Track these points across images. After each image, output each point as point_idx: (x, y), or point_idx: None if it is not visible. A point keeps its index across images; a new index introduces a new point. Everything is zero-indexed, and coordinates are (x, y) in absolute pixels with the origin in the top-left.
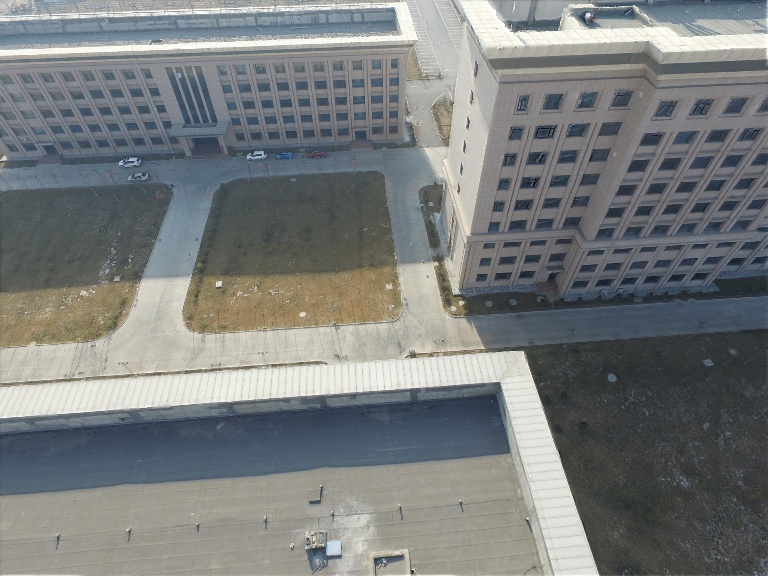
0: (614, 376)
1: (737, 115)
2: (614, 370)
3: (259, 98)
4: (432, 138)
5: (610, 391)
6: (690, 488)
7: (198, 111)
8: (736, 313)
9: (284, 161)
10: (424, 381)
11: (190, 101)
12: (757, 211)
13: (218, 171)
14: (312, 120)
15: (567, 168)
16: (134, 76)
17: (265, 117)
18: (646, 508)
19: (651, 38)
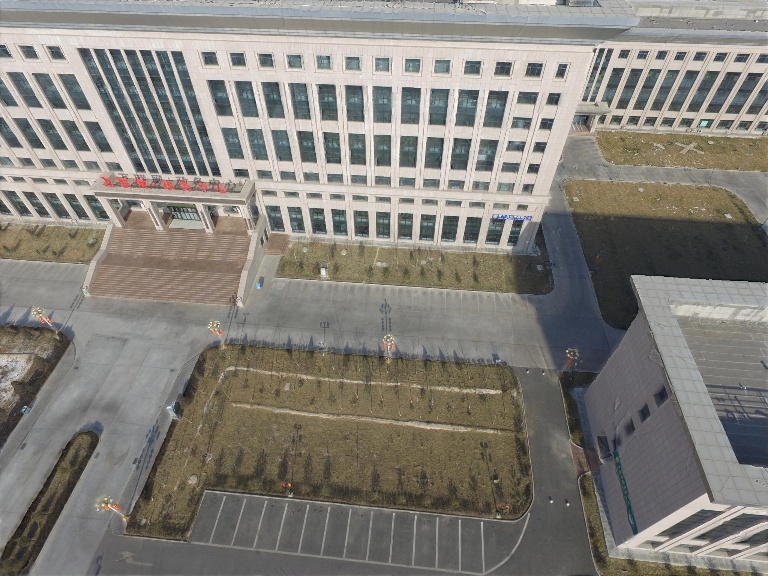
0: None
1: None
2: None
3: None
4: (534, 393)
5: None
6: None
7: None
8: None
9: None
10: None
11: None
12: None
13: None
14: None
15: None
16: None
17: None
18: None
19: None
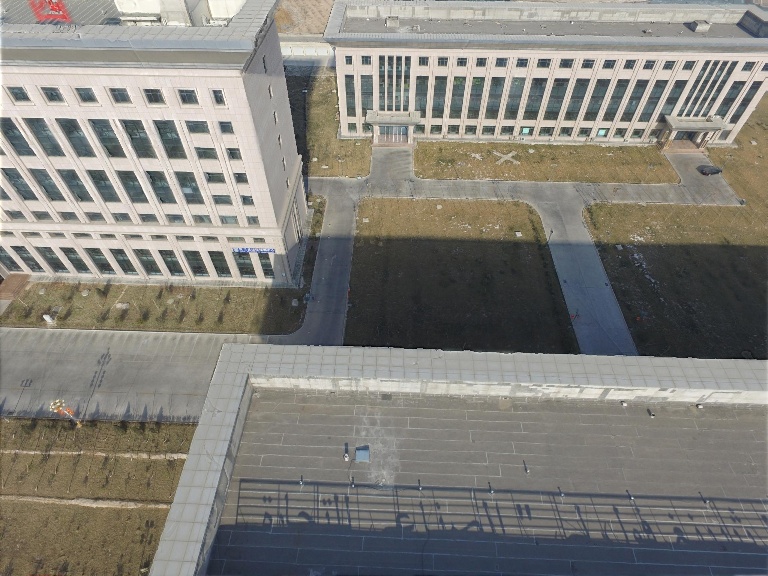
0: None
1: None
2: None
3: None
4: None
5: None
6: None
7: None
8: None
9: None
10: (371, 33)
11: None
12: None
13: None
14: None
15: None
16: None
17: None
18: None
19: None
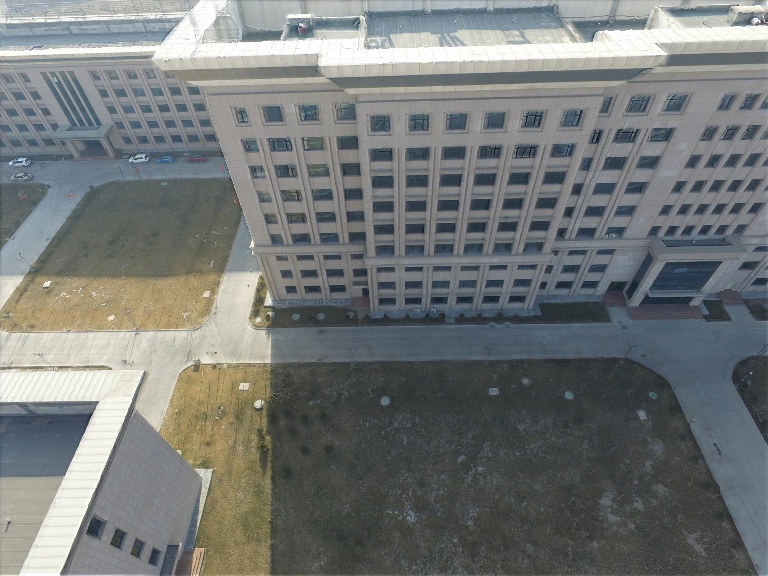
0: (387, 399)
1: (464, 132)
2: (391, 393)
3: (136, 103)
4: None
5: (377, 415)
6: (414, 524)
7: (81, 114)
8: (548, 340)
9: (164, 165)
10: (26, 395)
11: (71, 105)
12: (544, 233)
13: (98, 173)
14: (193, 125)
15: (323, 182)
16: (14, 80)
17: (147, 121)
18: (358, 541)
19: (326, 51)
